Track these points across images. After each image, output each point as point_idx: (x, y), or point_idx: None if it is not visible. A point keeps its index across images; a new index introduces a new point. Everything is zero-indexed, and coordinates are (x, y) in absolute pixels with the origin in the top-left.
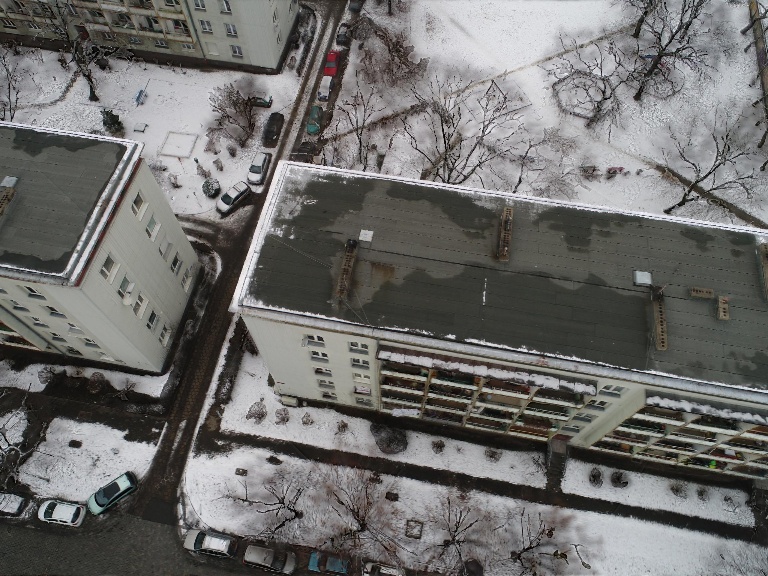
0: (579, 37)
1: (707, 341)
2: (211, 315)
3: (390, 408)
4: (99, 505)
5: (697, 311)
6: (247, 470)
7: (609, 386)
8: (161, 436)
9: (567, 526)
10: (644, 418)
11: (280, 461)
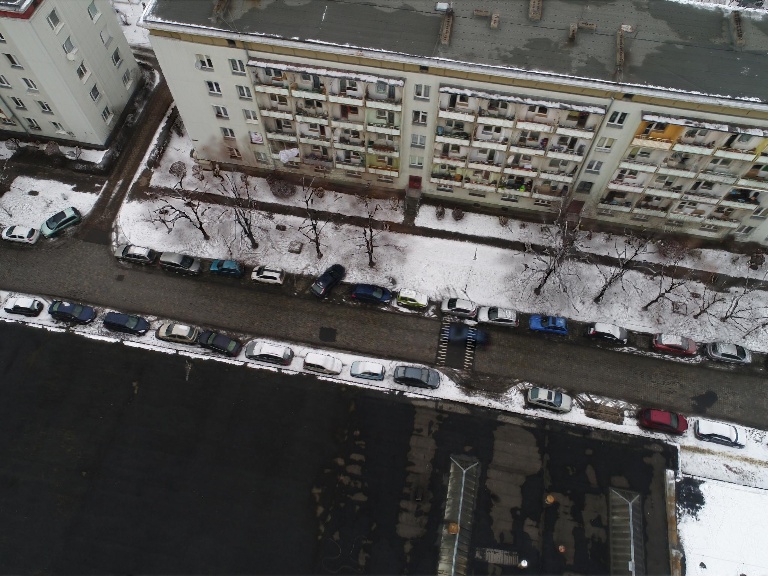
0: None
1: (481, 41)
2: (148, 112)
3: (277, 152)
4: (50, 228)
5: (477, 25)
6: (168, 211)
7: (420, 91)
8: (102, 189)
9: (416, 246)
10: (447, 117)
11: (195, 205)
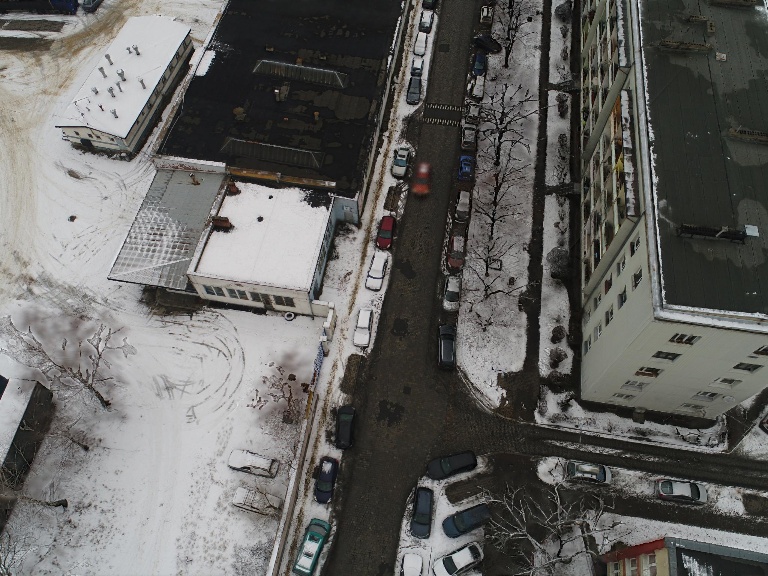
0: None
1: None
2: None
3: None
4: None
5: None
6: None
7: None
8: None
9: None
10: None
11: None
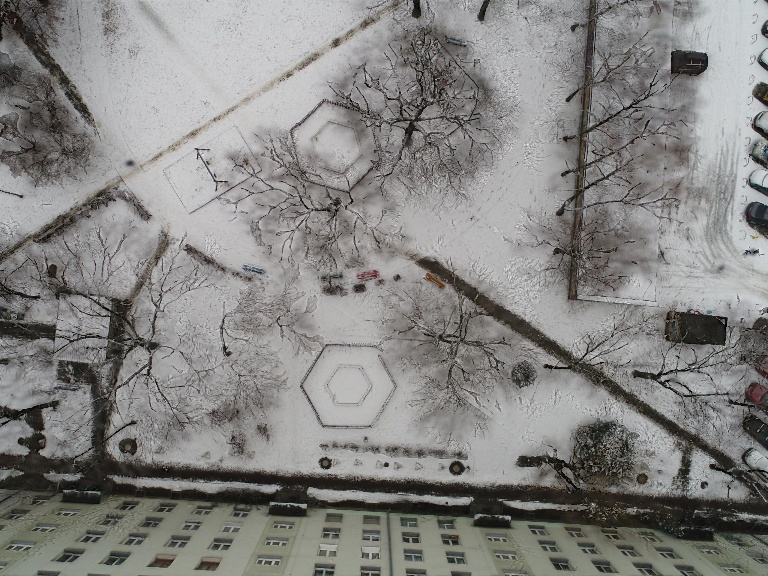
0: (333, 24)
1: None
2: None
3: None
4: None
5: None
6: None
7: None
8: None
9: None
10: None
11: None
